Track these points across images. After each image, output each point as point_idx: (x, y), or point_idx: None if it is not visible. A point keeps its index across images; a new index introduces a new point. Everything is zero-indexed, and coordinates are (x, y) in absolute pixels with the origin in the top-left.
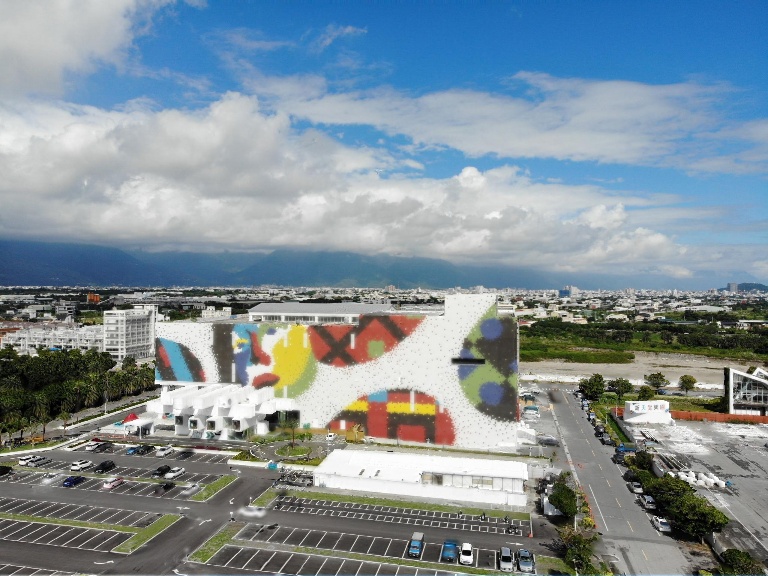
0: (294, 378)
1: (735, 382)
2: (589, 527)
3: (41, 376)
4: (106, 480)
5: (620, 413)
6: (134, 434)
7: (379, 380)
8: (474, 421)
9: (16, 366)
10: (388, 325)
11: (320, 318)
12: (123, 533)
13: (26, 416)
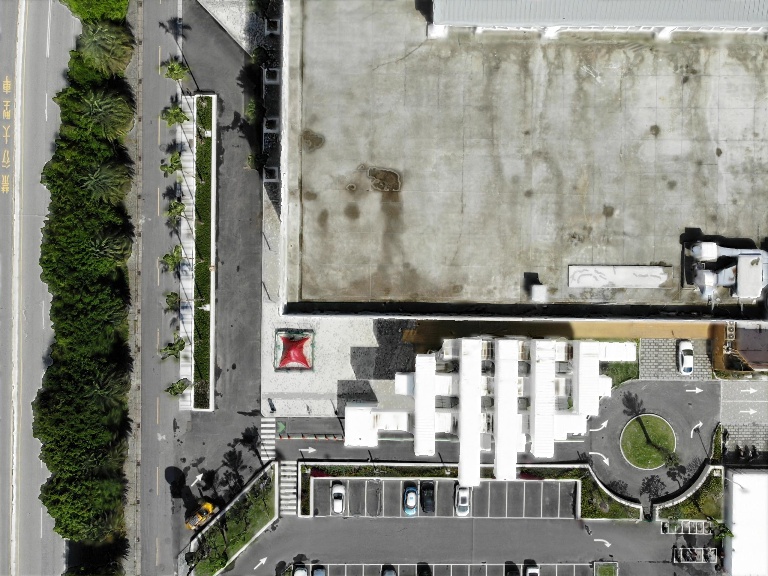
0: None
1: None
2: None
3: None
4: None
5: None
6: None
7: None
8: None
9: None
10: None
11: None
12: None
13: None
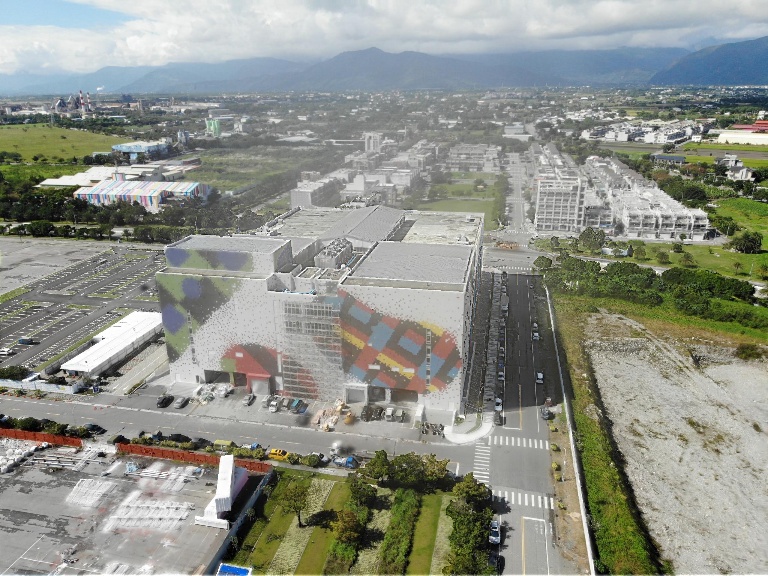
0: None
1: None
2: None
3: None
4: None
5: (275, 481)
6: None
7: None
8: None
9: None
10: None
11: None
12: None
13: None
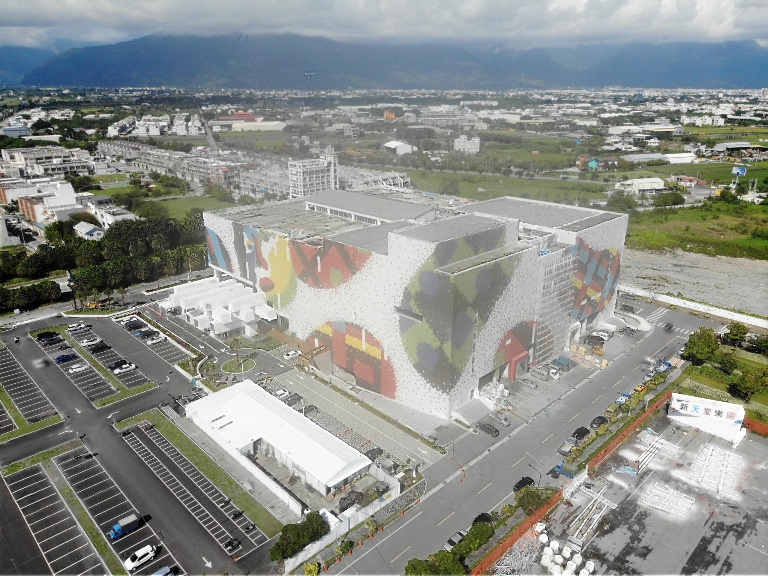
0: (283, 287)
1: None
2: (307, 575)
3: (190, 232)
4: (80, 364)
5: None
6: (172, 312)
7: (339, 309)
8: (412, 379)
9: (175, 222)
10: (344, 254)
11: (356, 216)
12: (13, 425)
13: (129, 278)
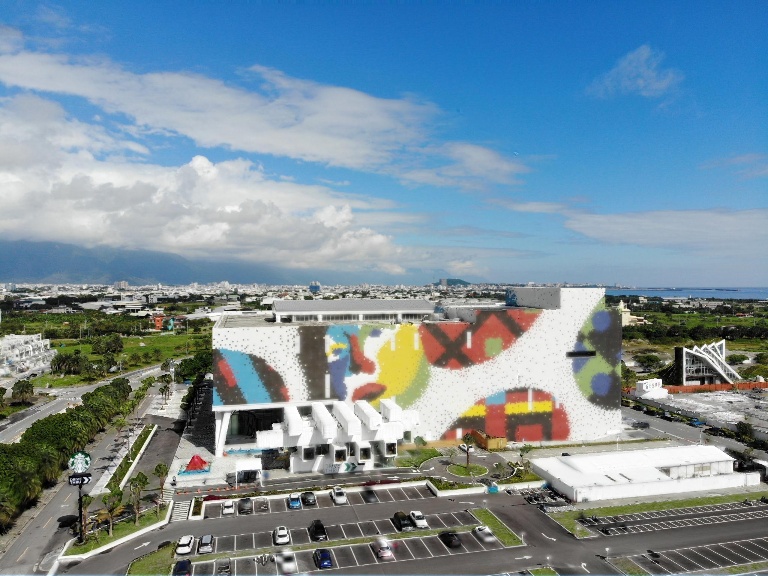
0: (404, 386)
1: (685, 359)
2: None
3: None
4: None
5: None
6: (237, 481)
7: (497, 380)
8: (587, 413)
9: None
10: (506, 320)
11: (364, 316)
12: None
13: None
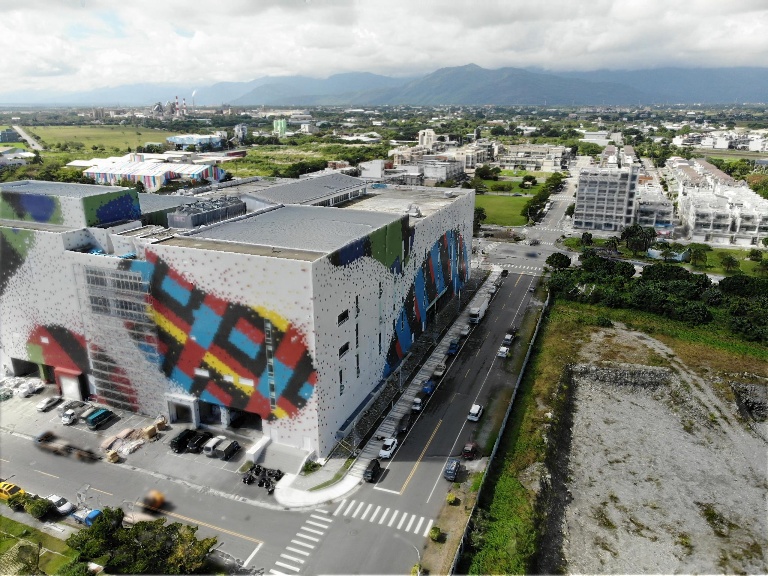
0: None
1: None
2: None
3: None
4: None
5: None
6: None
7: None
8: None
9: None
10: None
11: None
12: None
13: None
